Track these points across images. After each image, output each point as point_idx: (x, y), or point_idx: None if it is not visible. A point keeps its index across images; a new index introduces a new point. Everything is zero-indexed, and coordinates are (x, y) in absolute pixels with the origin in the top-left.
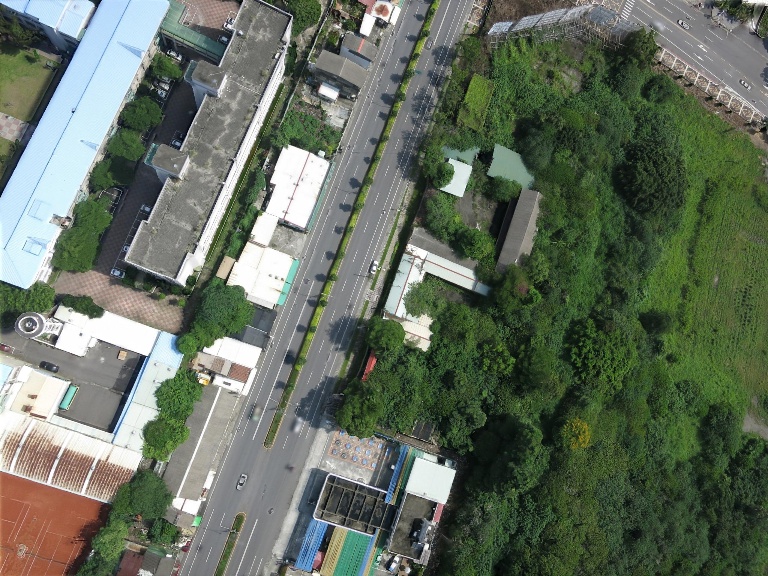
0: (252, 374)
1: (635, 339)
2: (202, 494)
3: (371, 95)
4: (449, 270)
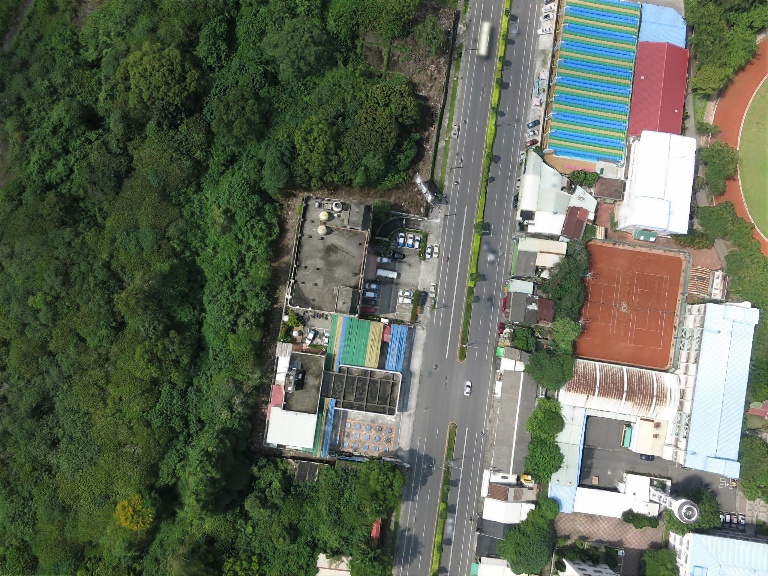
0: (485, 491)
1: None
2: (501, 376)
3: None
4: None
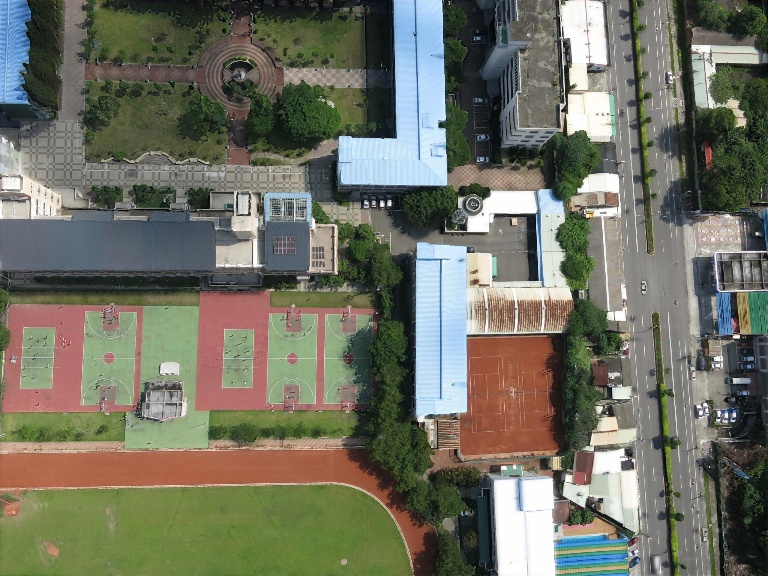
0: None
1: None
2: (623, 305)
3: None
4: (734, 54)
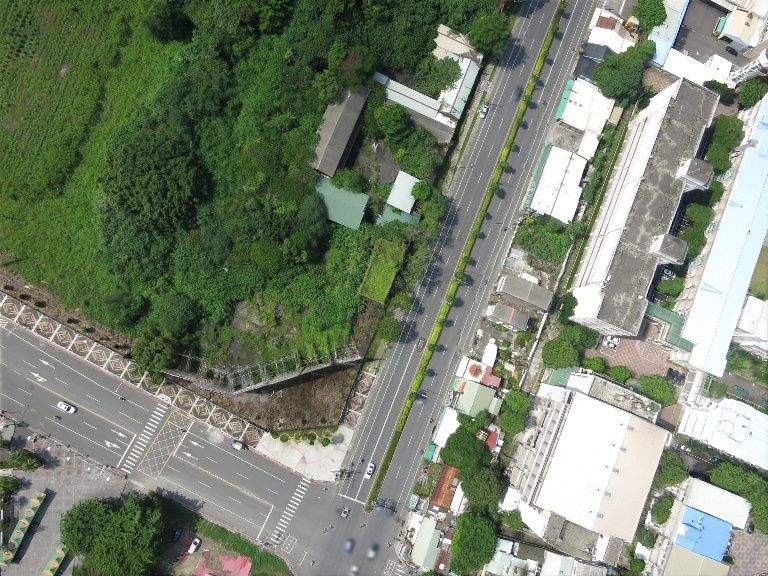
0: (594, 24)
1: (207, 2)
2: None
3: (484, 284)
4: (414, 100)
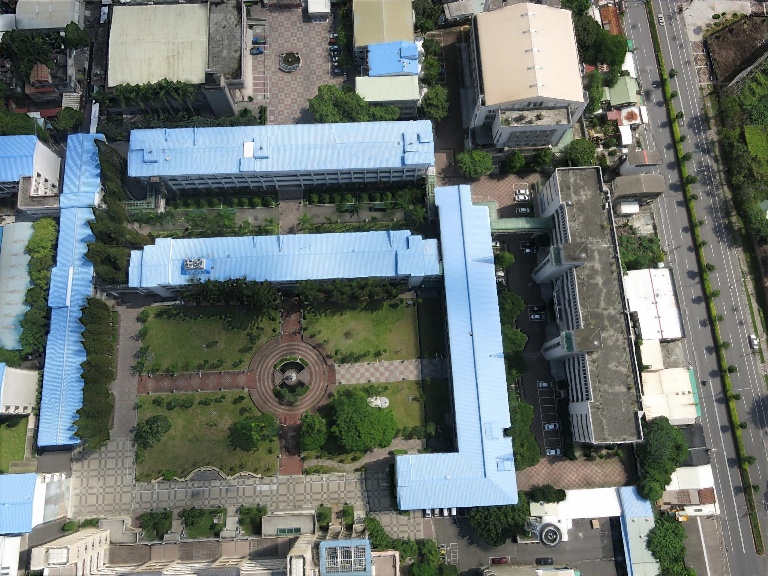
0: None
1: None
2: None
3: None
4: None
